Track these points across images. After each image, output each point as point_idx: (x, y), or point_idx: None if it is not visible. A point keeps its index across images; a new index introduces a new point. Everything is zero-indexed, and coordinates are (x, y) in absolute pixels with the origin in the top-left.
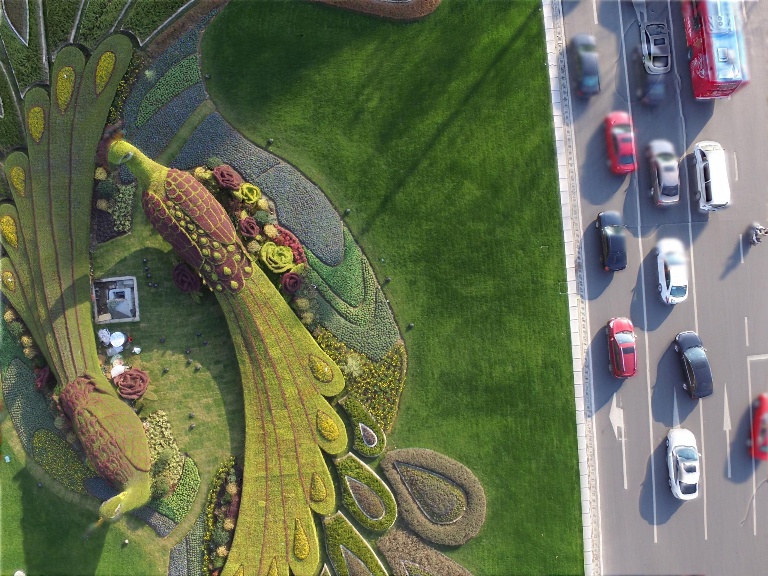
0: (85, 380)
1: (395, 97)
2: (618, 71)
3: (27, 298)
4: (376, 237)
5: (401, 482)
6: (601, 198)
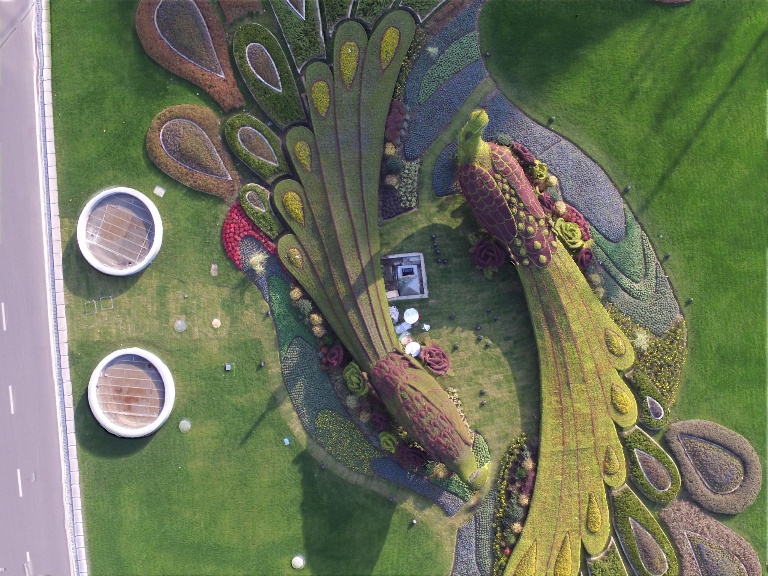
0: (398, 356)
1: (667, 78)
2: None
3: (318, 275)
4: (655, 214)
5: (684, 453)
6: None
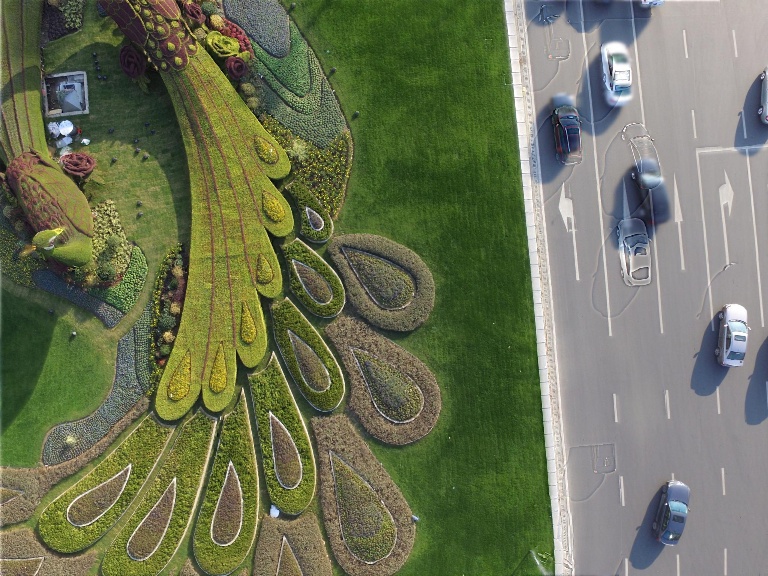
0: (31, 155)
1: None
2: None
3: None
4: (321, 30)
5: (349, 267)
6: None
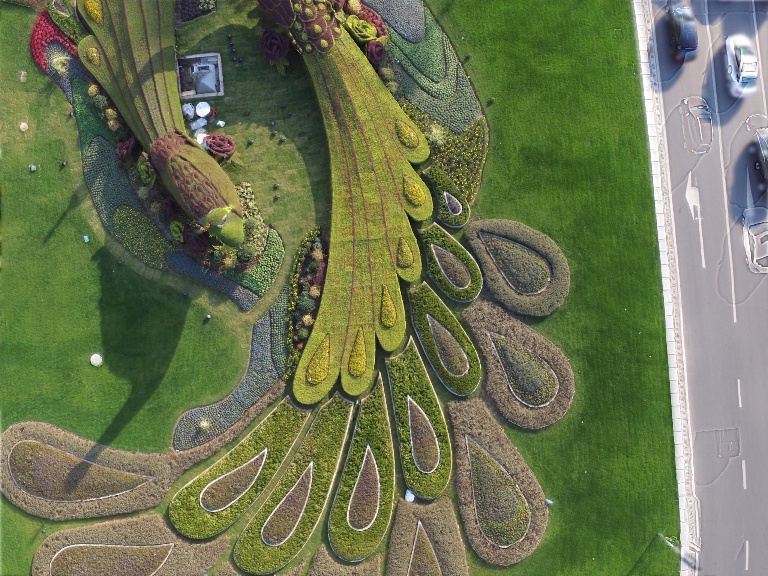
0: (176, 135)
1: None
2: None
3: (113, 69)
4: (456, 16)
5: (486, 252)
6: None
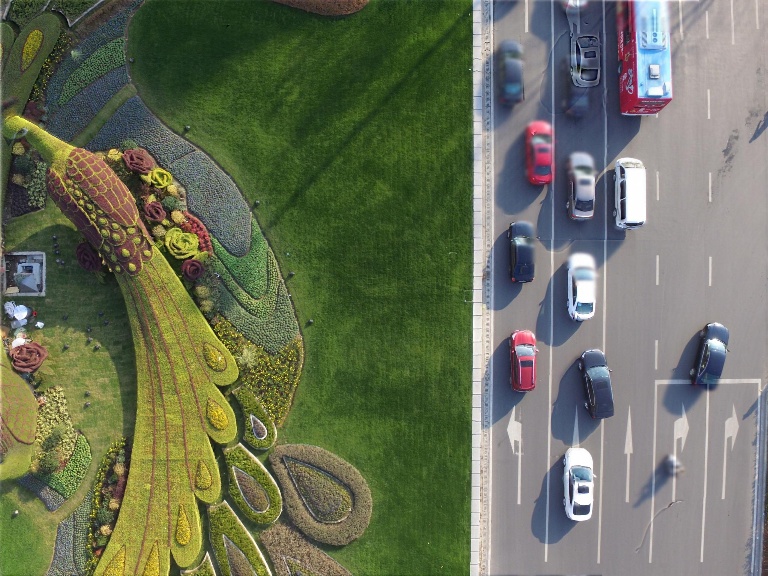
0: None
1: (314, 93)
2: (545, 81)
3: None
4: (283, 231)
5: (288, 477)
6: (515, 208)
